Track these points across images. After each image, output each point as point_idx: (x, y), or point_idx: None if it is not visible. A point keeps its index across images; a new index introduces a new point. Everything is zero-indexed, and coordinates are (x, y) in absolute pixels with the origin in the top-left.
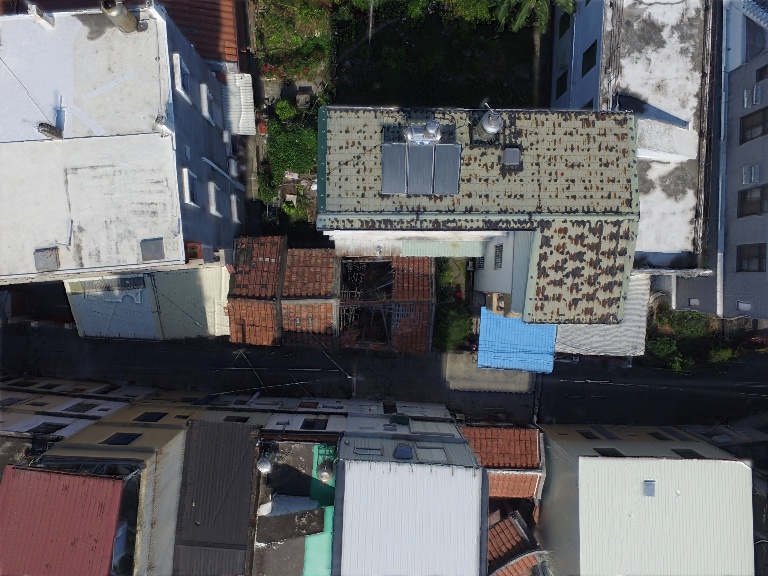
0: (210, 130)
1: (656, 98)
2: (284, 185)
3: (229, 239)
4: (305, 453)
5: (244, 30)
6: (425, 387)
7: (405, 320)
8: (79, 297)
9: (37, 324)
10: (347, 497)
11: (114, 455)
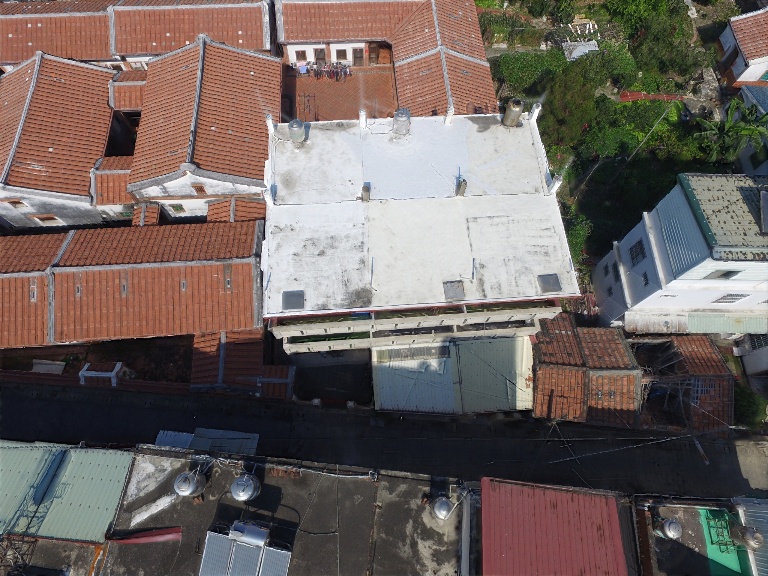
0: None
1: None
2: None
3: None
4: (693, 525)
5: None
6: (722, 485)
7: (705, 397)
8: (383, 366)
9: (319, 402)
10: None
11: None
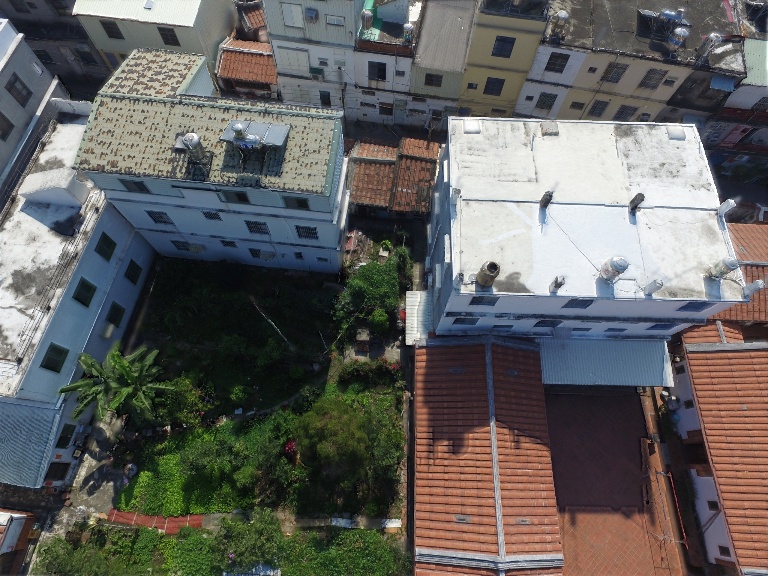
0: None
1: (40, 231)
2: None
3: None
4: None
5: (414, 415)
6: None
7: None
8: None
9: None
10: None
11: (501, 20)
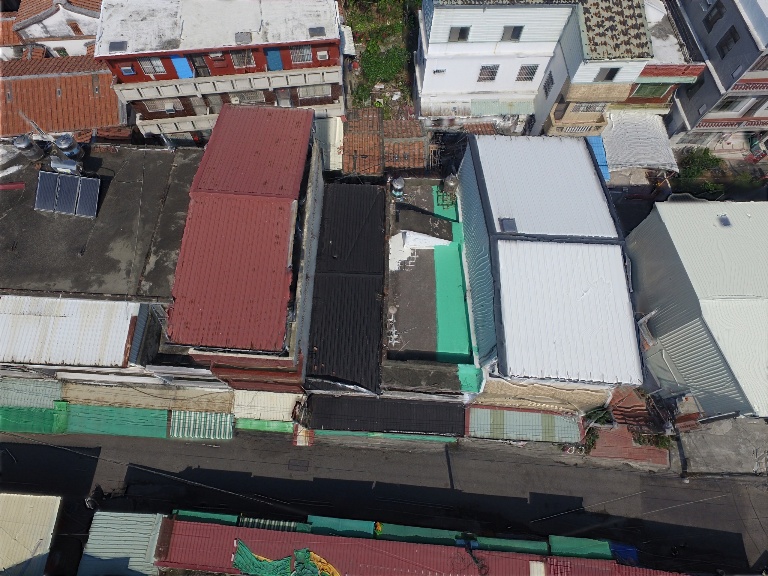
0: None
1: None
2: (374, 93)
3: None
4: (426, 196)
5: None
6: None
7: None
8: None
9: None
10: (481, 154)
11: None
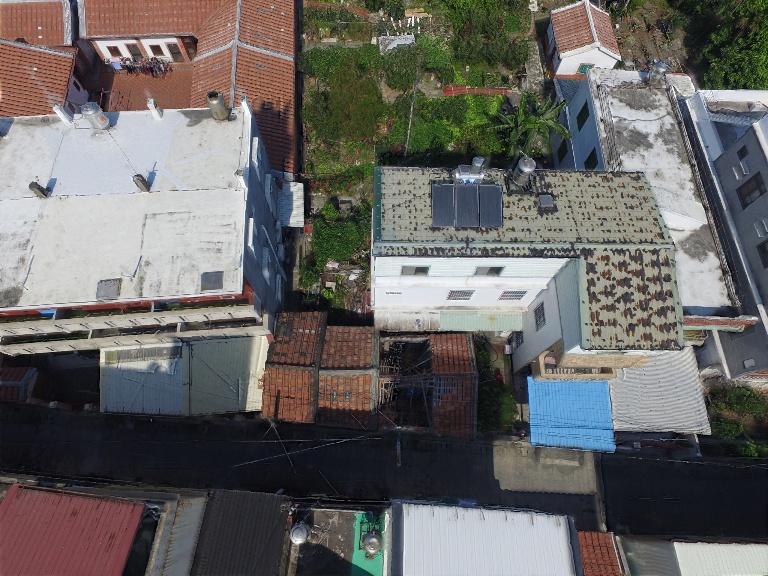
0: (268, 212)
1: (657, 182)
2: (325, 273)
3: (272, 310)
4: (345, 530)
5: (297, 161)
6: (471, 486)
7: (447, 396)
8: (111, 367)
9: (56, 404)
10: (407, 552)
11: None
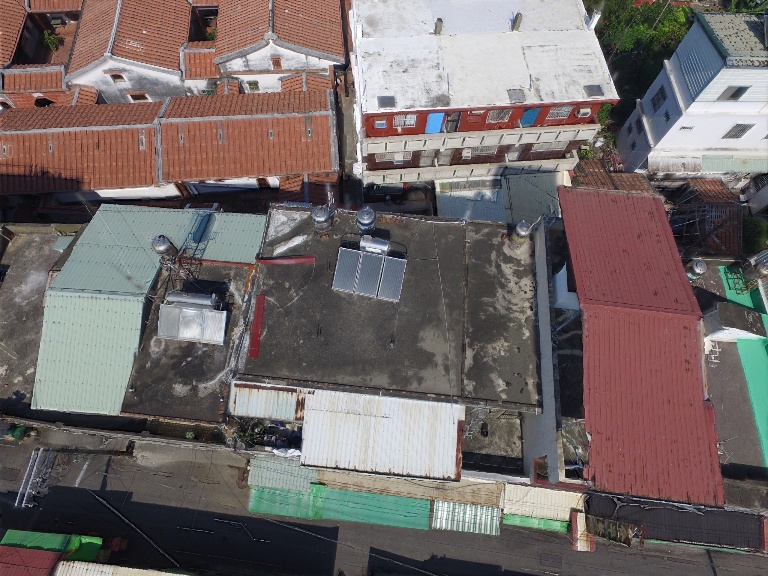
0: None
1: None
2: None
3: None
4: (714, 277)
5: None
6: None
7: (718, 221)
8: (445, 196)
9: None
10: None
11: None
